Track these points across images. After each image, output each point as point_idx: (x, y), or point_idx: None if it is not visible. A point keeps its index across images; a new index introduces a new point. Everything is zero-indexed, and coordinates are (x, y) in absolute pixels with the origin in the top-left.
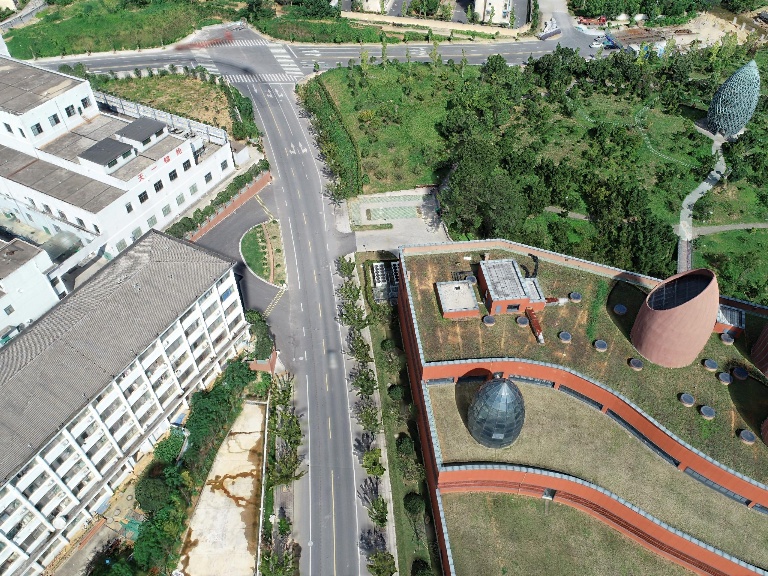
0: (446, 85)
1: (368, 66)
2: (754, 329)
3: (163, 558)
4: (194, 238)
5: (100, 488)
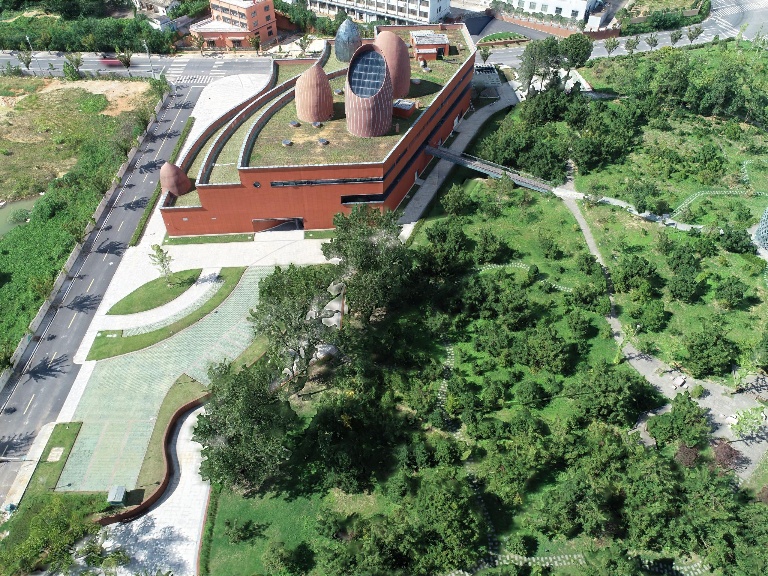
0: (761, 89)
1: (739, 38)
2: (400, 123)
3: (321, 33)
4: (506, 19)
5: (342, 4)
